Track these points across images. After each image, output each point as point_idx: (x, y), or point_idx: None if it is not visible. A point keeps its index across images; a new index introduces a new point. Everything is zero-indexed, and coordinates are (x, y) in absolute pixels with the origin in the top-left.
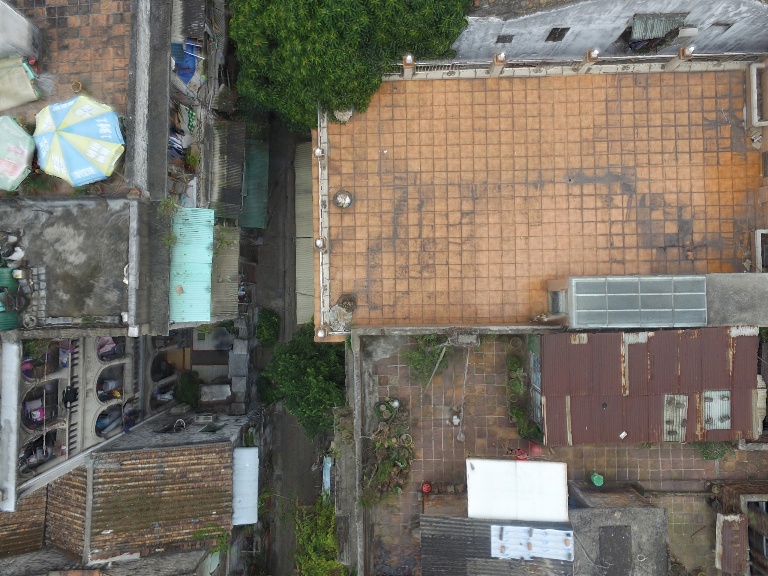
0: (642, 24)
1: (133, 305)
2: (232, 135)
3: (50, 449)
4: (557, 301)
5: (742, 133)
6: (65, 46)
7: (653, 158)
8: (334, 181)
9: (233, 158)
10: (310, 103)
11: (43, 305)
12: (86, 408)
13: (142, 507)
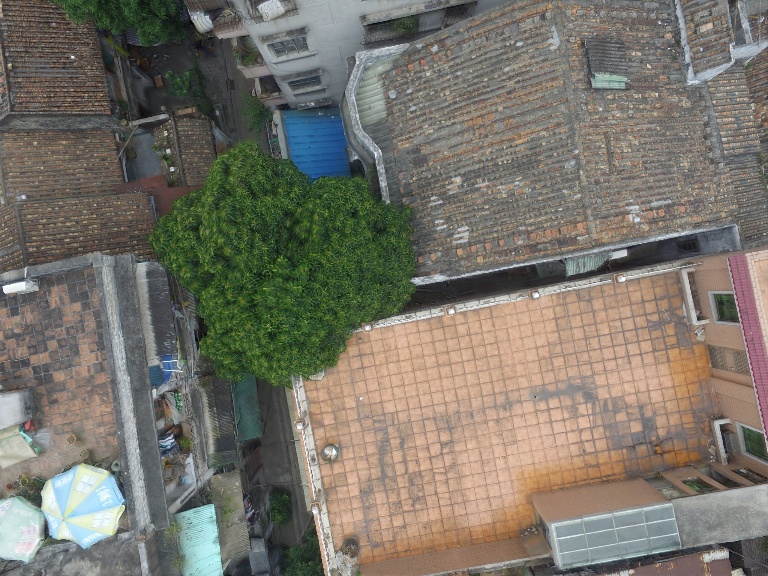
0: (574, 262)
1: None
2: (217, 387)
3: None
4: None
5: (685, 329)
6: (54, 399)
7: (608, 365)
8: (319, 433)
9: (222, 408)
10: (284, 377)
11: None
12: None
13: None
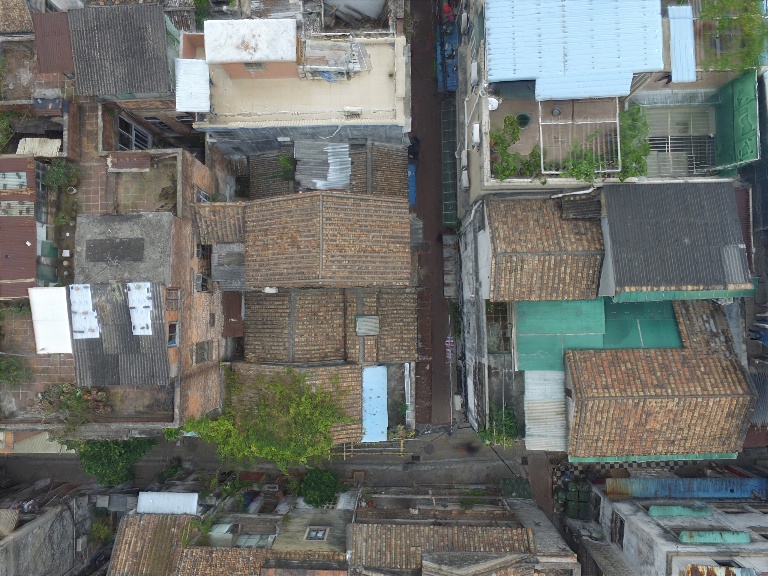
0: None
1: None
2: None
3: None
4: None
5: None
6: None
7: None
8: None
9: None
10: None
11: None
12: None
13: None
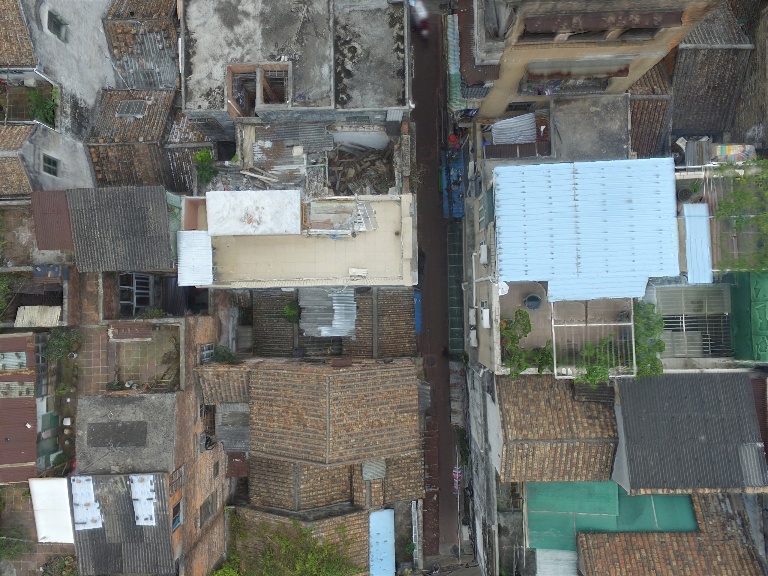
0: None
1: None
2: None
3: None
4: None
5: None
6: None
7: None
8: None
9: None
10: None
11: None
12: None
13: None
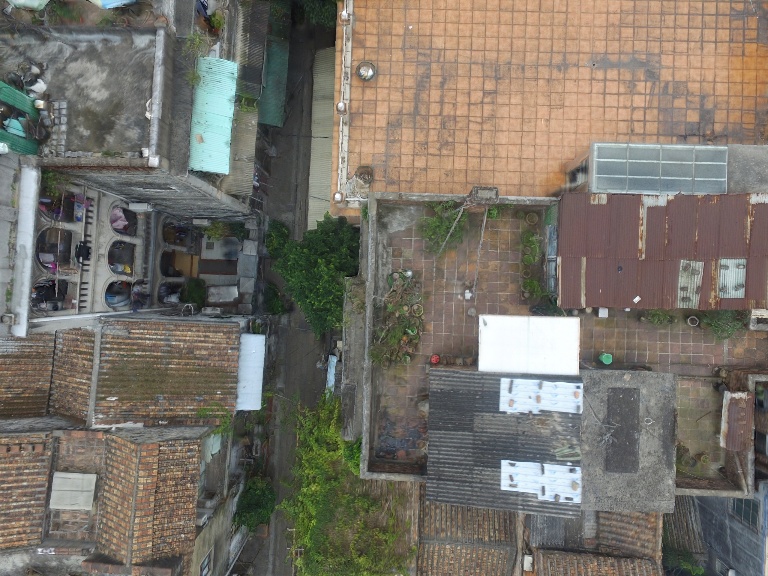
0: None
1: (155, 135)
2: (256, 13)
3: (60, 303)
4: (575, 184)
5: None
6: None
7: (678, 46)
8: (357, 54)
9: (255, 37)
10: None
11: (63, 140)
12: (97, 272)
13: (148, 378)
